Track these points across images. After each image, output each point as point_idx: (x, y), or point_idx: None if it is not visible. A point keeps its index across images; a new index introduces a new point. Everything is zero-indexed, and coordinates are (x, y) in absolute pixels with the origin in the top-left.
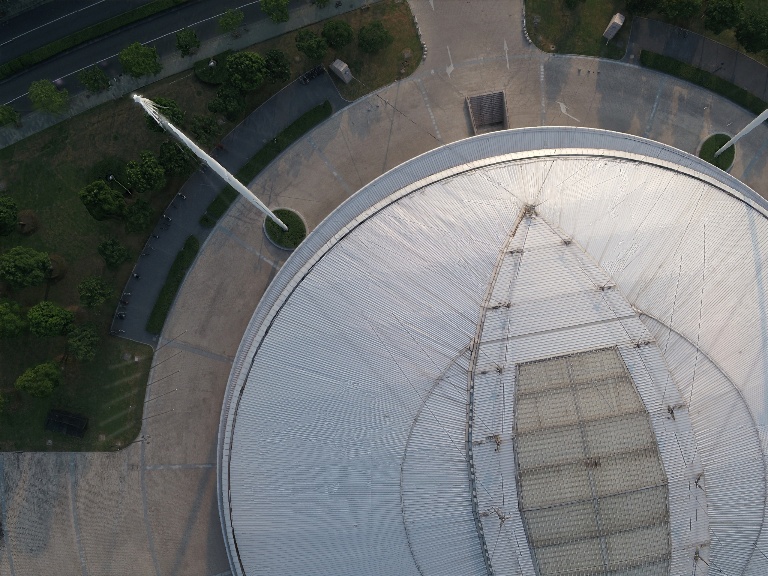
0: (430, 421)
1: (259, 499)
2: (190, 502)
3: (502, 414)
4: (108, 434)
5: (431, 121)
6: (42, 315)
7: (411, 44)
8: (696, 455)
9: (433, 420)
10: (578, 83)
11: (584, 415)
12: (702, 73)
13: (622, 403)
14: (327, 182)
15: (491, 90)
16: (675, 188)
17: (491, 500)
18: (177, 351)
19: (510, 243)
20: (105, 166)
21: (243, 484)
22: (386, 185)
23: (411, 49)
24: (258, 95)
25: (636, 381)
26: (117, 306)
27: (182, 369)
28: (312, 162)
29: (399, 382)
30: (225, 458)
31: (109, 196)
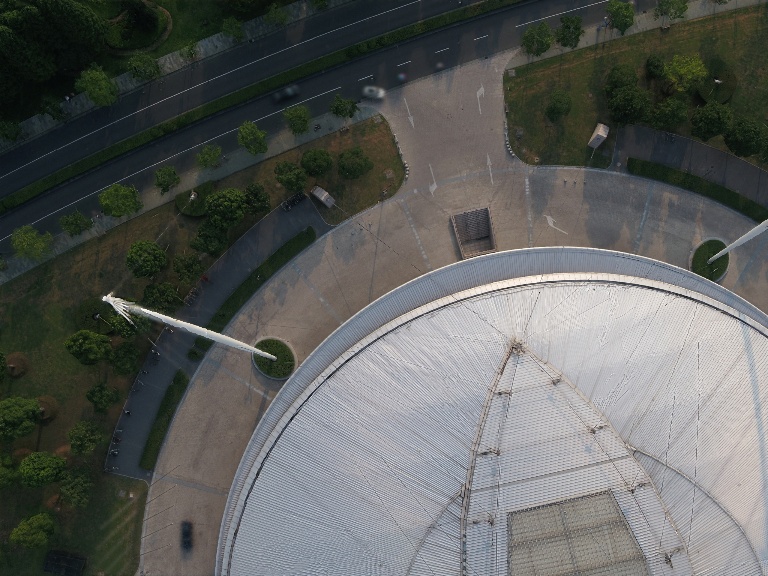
0: (424, 571)
1: None
2: None
3: (496, 565)
4: (107, 571)
5: (416, 241)
6: (33, 468)
7: (392, 164)
8: None
9: (427, 570)
10: (564, 195)
11: (580, 564)
12: (692, 178)
13: (618, 550)
14: (314, 308)
15: (476, 207)
16: (666, 311)
17: None
18: (171, 485)
19: (498, 383)
20: (91, 305)
21: None
22: (372, 316)
23: (393, 169)
24: (241, 224)
25: (632, 526)
26: (110, 443)
27: (177, 503)
28: (298, 289)
29: (391, 530)
30: None
31: (94, 345)
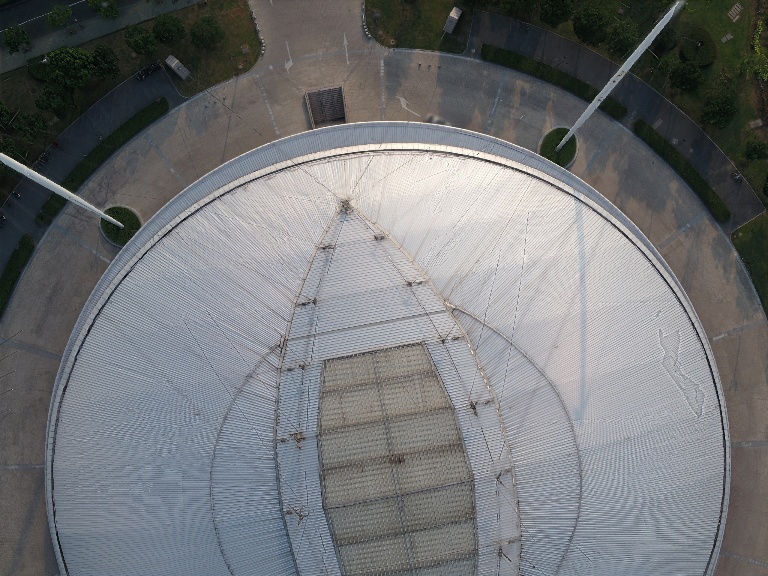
0: (239, 419)
1: (79, 499)
2: (27, 503)
3: (307, 411)
4: None
5: (269, 117)
6: None
7: (249, 39)
8: (503, 451)
9: (242, 418)
10: (418, 78)
11: (388, 411)
12: (543, 67)
13: (427, 399)
14: (164, 179)
15: (330, 85)
16: (500, 182)
17: (295, 498)
18: (13, 351)
19: (323, 239)
20: None
21: (65, 484)
22: (215, 181)
23: (249, 44)
24: (94, 92)
25: (443, 377)
26: None
27: (18, 369)
28: (149, 159)
29: (210, 380)
30: (49, 458)
31: None
